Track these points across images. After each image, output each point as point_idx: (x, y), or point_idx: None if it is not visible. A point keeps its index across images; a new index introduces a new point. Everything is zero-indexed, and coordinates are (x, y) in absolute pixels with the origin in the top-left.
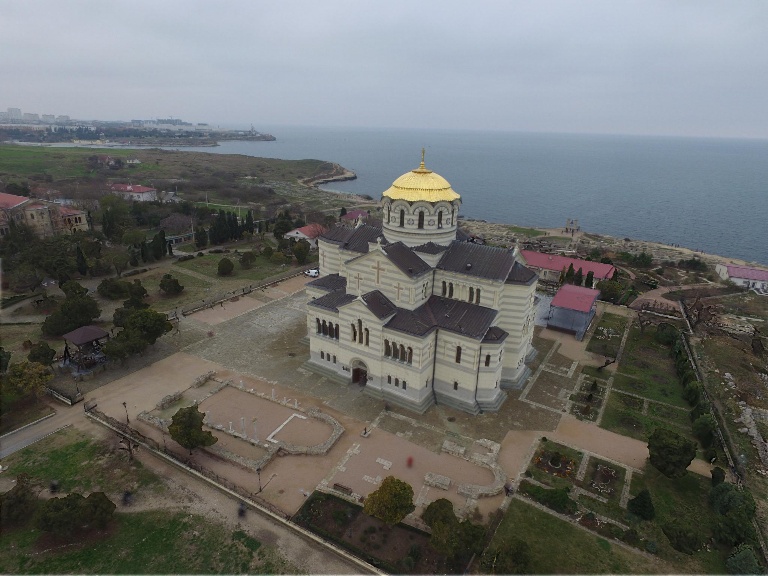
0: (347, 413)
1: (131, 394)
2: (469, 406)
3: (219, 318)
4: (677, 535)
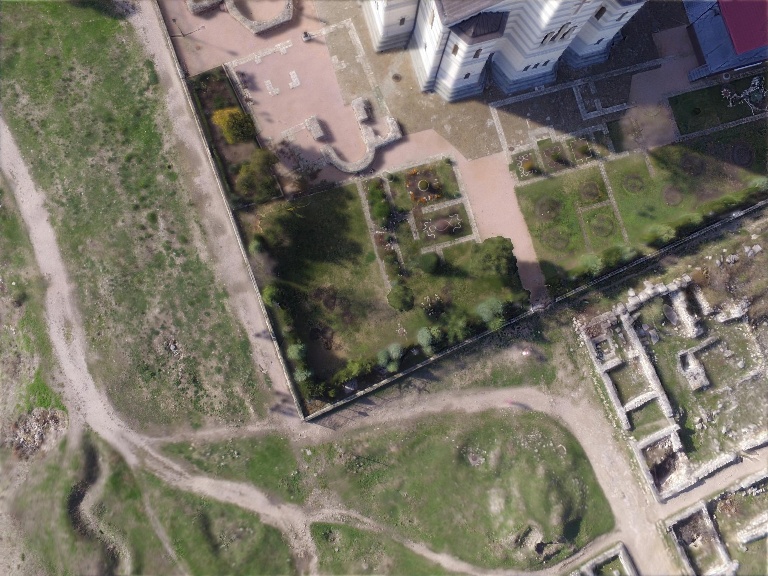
0: None
1: None
2: (424, 77)
3: None
4: (388, 296)
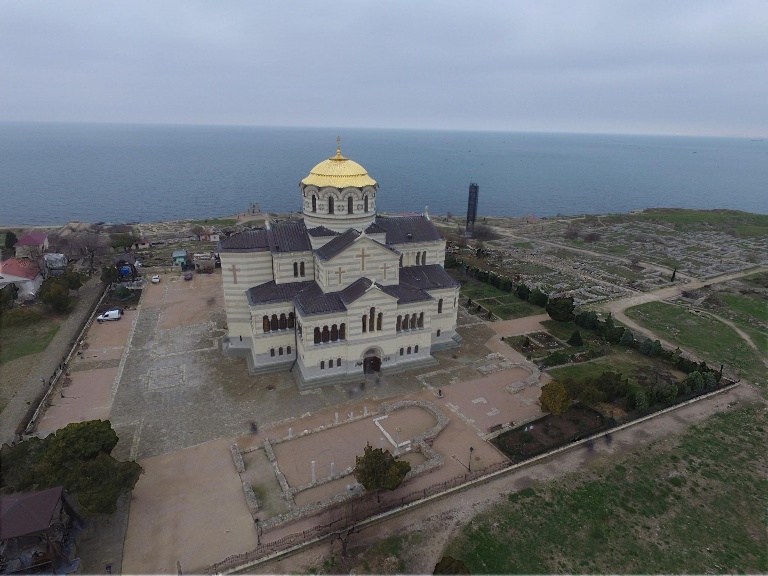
0: (403, 394)
1: (189, 531)
2: (453, 343)
3: (95, 408)
4: (619, 335)
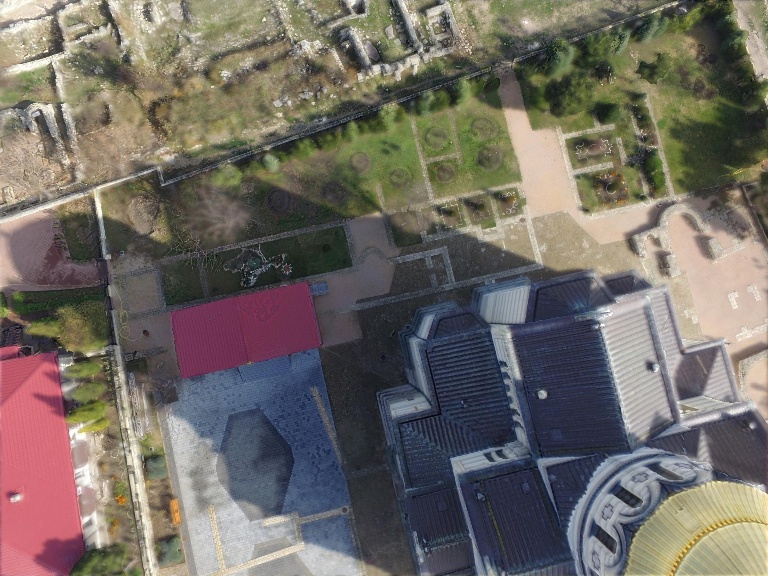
0: None
1: None
2: None
3: None
4: None
